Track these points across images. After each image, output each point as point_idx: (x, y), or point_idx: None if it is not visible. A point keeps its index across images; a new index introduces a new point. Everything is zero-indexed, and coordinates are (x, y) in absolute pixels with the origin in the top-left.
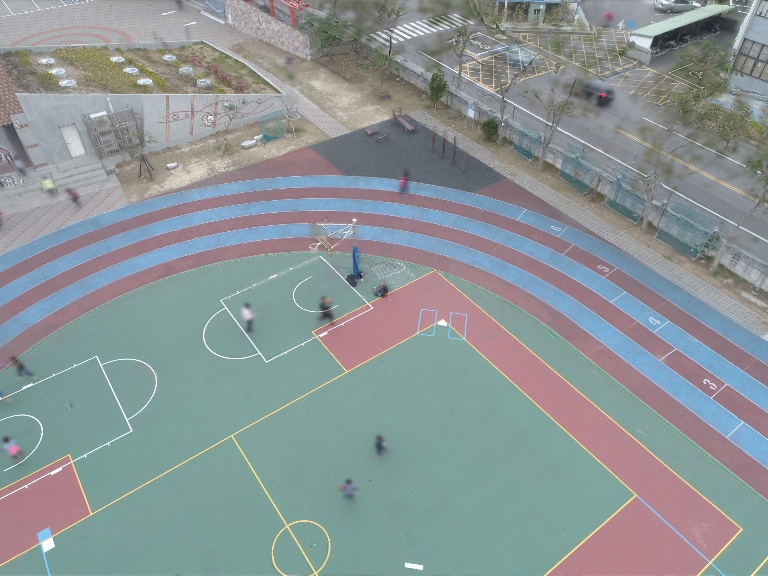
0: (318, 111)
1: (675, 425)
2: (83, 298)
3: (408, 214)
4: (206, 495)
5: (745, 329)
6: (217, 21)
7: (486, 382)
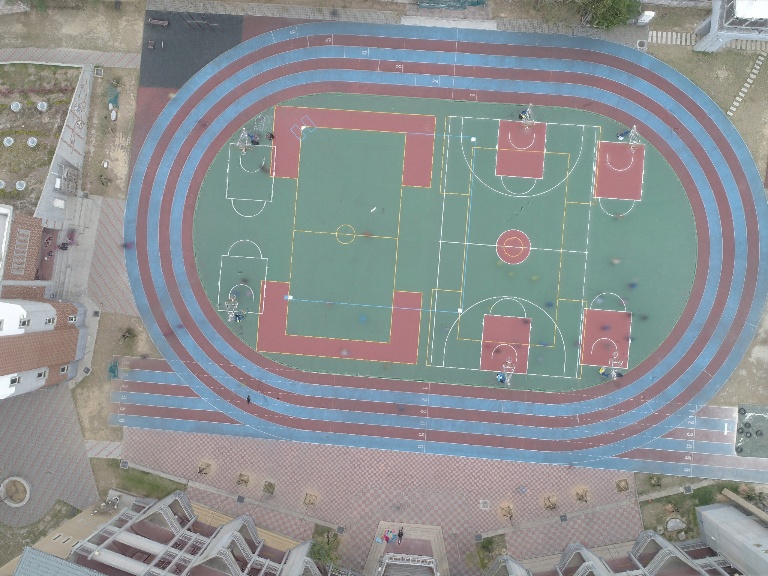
0: (104, 55)
1: (400, 96)
2: (183, 247)
3: (232, 85)
4: (309, 249)
5: (393, 25)
6: None
7: (338, 137)
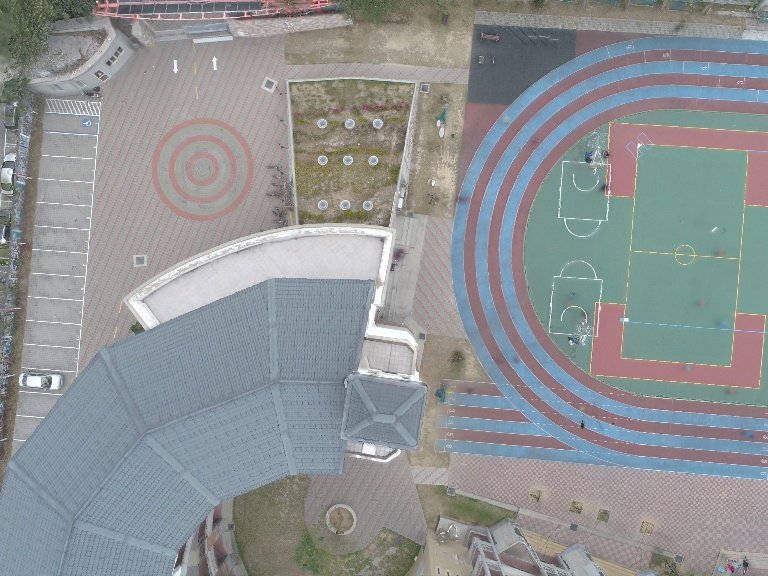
0: (431, 70)
1: (741, 112)
2: (513, 268)
3: (565, 102)
4: (646, 270)
5: (735, 40)
6: (224, 41)
7: (677, 155)
